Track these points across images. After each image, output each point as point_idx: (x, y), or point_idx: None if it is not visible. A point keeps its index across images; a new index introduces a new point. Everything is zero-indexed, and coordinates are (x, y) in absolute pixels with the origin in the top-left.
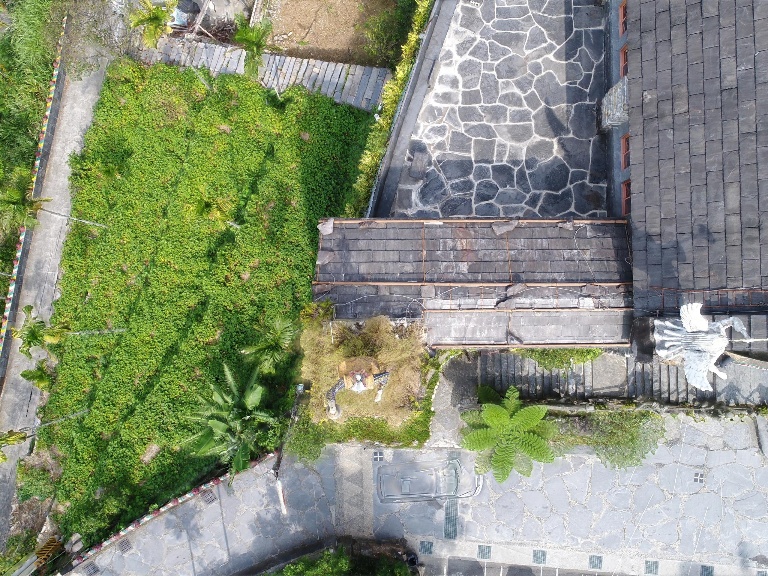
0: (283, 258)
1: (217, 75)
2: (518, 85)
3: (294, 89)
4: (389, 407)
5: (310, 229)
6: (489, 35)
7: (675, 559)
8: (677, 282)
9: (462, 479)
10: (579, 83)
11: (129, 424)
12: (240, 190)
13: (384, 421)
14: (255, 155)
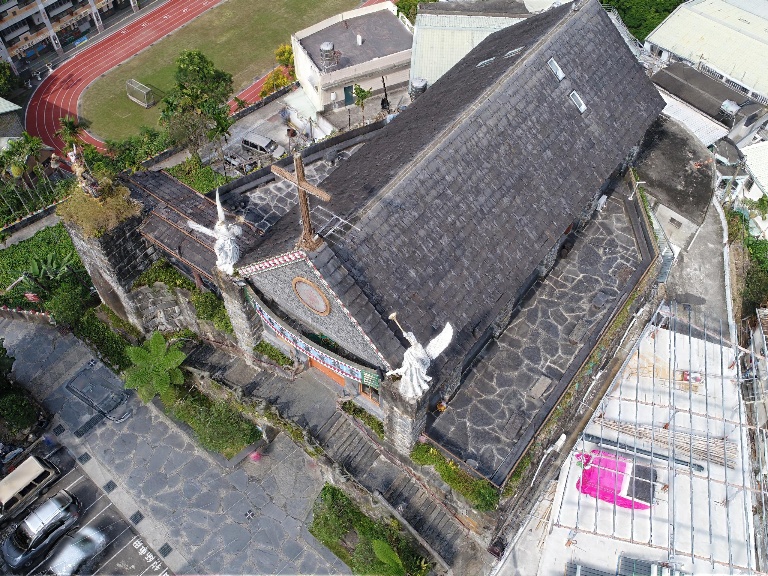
0: None
1: None
2: None
3: None
4: (90, 222)
5: None
6: None
7: (185, 557)
8: None
9: (119, 408)
10: None
11: (6, 275)
12: None
13: (114, 341)
14: None
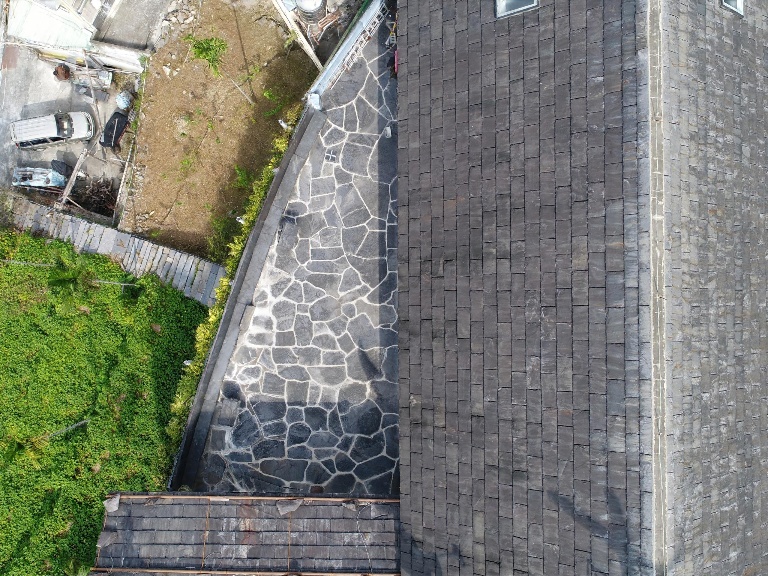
0: (133, 451)
1: (81, 252)
2: (332, 327)
3: (148, 278)
4: None
5: (159, 423)
6: (303, 276)
7: None
8: None
9: None
10: (392, 326)
11: None
12: (98, 374)
13: None
14: (112, 339)
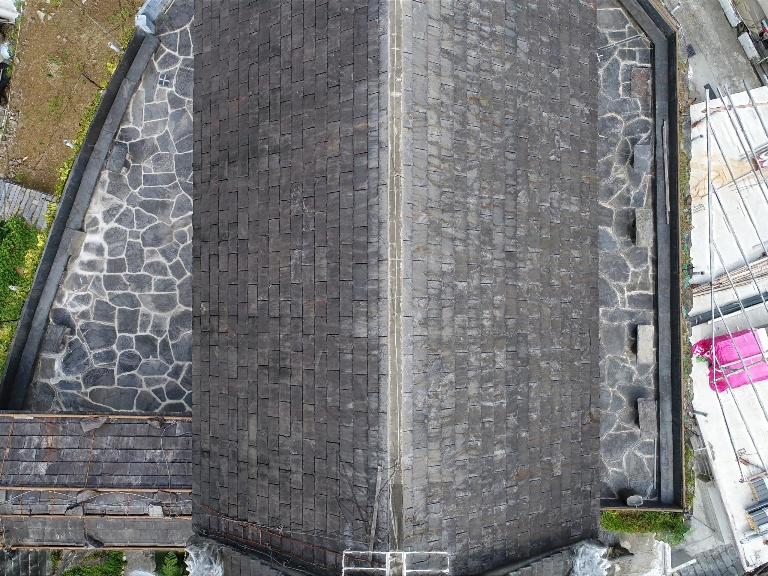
0: None
1: None
2: (163, 254)
3: (13, 221)
4: None
5: None
6: (135, 202)
7: None
8: (218, 504)
9: None
10: None
11: None
12: None
13: (71, 572)
14: None
